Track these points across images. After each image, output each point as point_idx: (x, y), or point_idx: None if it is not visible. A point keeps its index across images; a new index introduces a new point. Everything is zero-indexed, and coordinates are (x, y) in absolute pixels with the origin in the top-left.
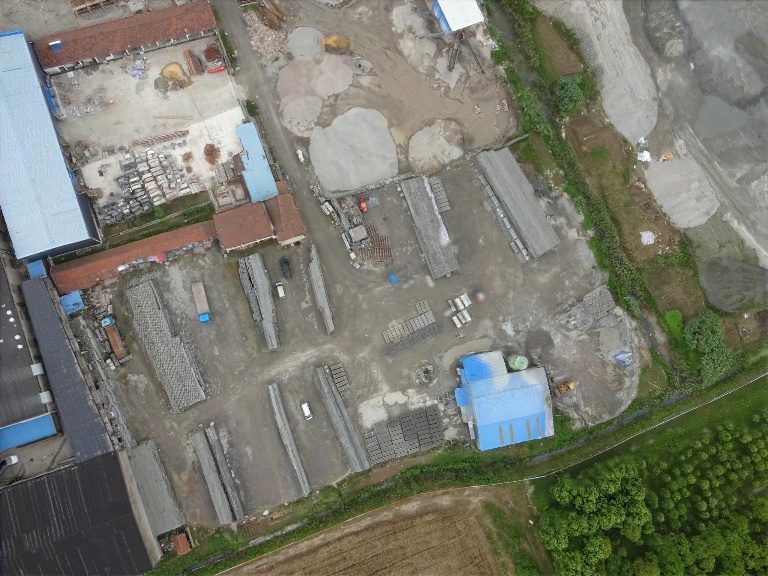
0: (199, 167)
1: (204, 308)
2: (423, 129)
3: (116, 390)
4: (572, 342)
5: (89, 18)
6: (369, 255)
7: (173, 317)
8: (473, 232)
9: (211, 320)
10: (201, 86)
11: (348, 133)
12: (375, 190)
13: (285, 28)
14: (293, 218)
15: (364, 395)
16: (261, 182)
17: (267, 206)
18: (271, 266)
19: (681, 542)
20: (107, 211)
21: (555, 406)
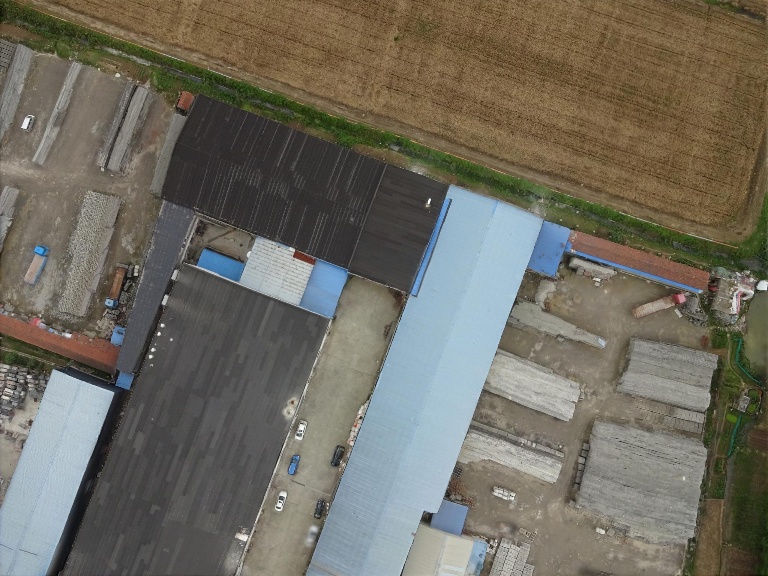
0: None
1: (37, 259)
2: None
3: None
4: None
5: None
6: None
7: (68, 271)
8: None
9: None
10: None
11: None
12: None
13: None
14: None
15: None
16: None
17: None
18: None
19: None
20: None
21: None
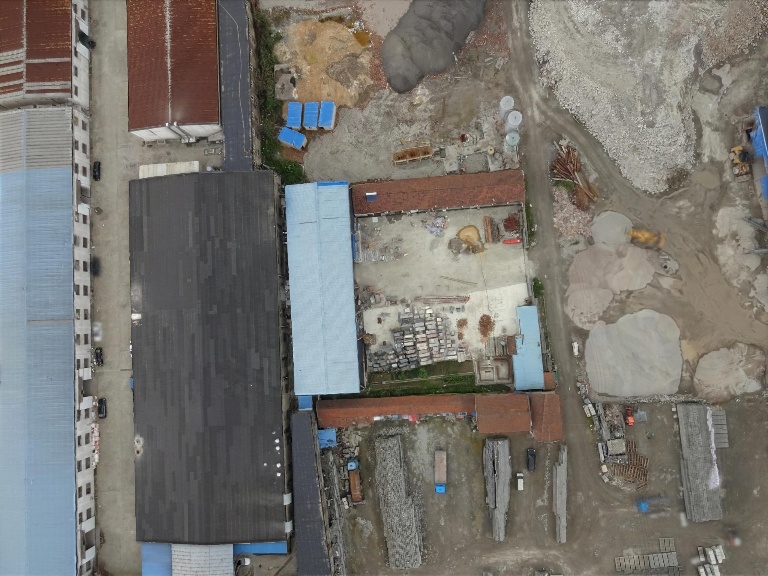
0: (471, 336)
1: (442, 478)
2: (719, 350)
3: (344, 528)
4: None
5: (404, 167)
6: (622, 472)
7: (410, 475)
8: (748, 480)
9: (445, 491)
10: (493, 254)
11: (634, 339)
12: (646, 404)
13: (593, 209)
14: (555, 421)
15: None
16: (529, 370)
17: (531, 401)
18: (516, 453)
19: None
20: (377, 359)
21: None
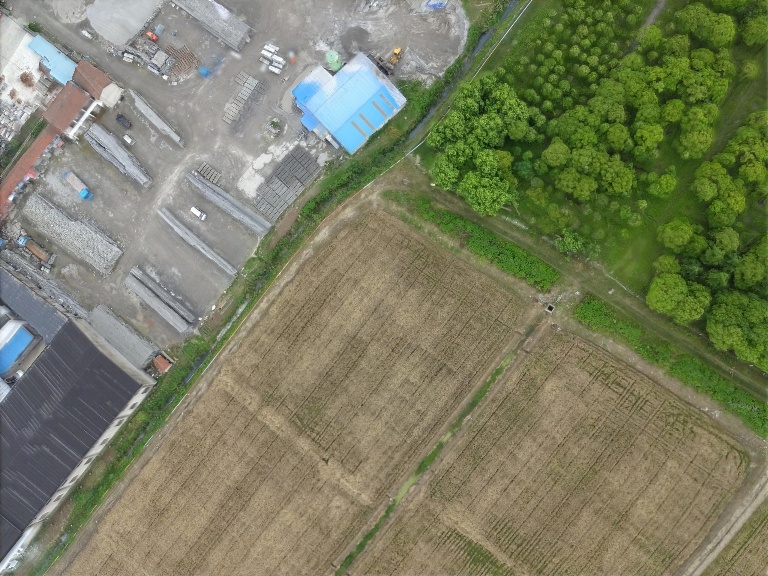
0: (25, 94)
1: (83, 188)
2: None
3: (59, 285)
4: (384, 20)
5: None
6: (179, 69)
7: (68, 210)
8: None
9: (93, 194)
10: None
11: None
12: (156, 19)
13: None
14: (97, 76)
15: (237, 175)
16: (67, 71)
17: (75, 81)
18: (114, 128)
19: (576, 111)
20: None
21: (399, 80)
